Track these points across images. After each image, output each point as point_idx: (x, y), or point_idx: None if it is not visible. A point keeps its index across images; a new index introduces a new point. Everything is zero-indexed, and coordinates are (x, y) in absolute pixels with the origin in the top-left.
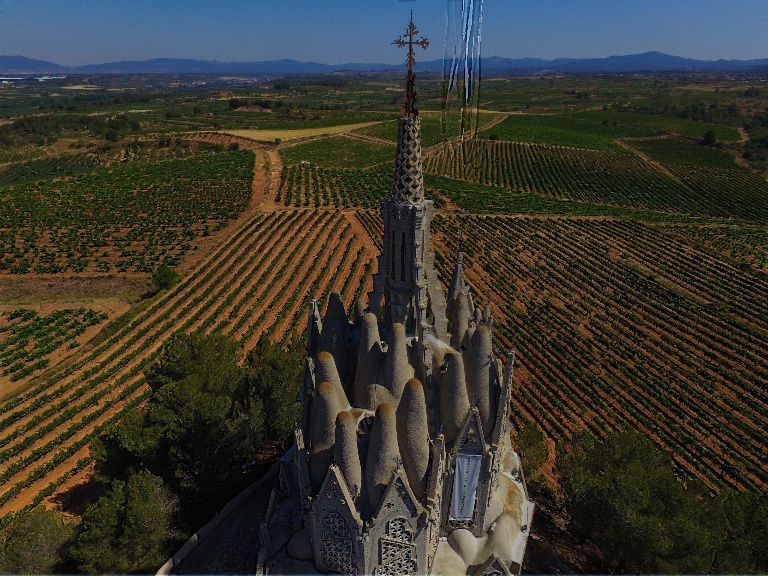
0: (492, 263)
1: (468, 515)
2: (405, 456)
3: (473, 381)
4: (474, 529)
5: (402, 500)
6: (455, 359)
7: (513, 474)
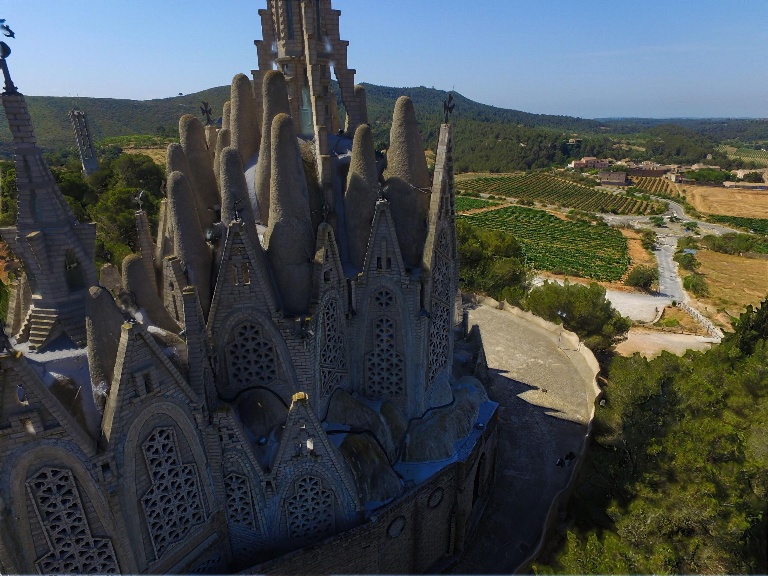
0: None
1: None
2: None
3: None
4: None
5: None
6: None
7: None
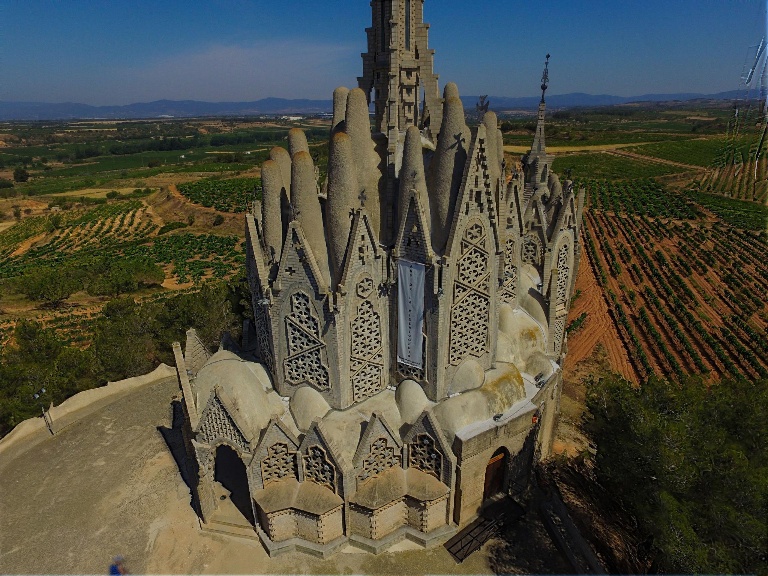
0: (740, 277)
1: (417, 359)
2: (329, 232)
3: (436, 172)
4: (427, 386)
5: (303, 268)
6: (408, 130)
7: (536, 379)
